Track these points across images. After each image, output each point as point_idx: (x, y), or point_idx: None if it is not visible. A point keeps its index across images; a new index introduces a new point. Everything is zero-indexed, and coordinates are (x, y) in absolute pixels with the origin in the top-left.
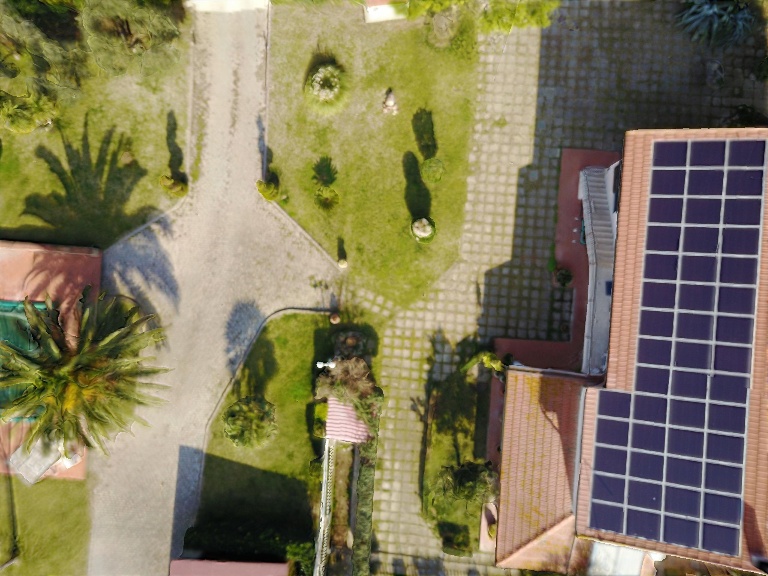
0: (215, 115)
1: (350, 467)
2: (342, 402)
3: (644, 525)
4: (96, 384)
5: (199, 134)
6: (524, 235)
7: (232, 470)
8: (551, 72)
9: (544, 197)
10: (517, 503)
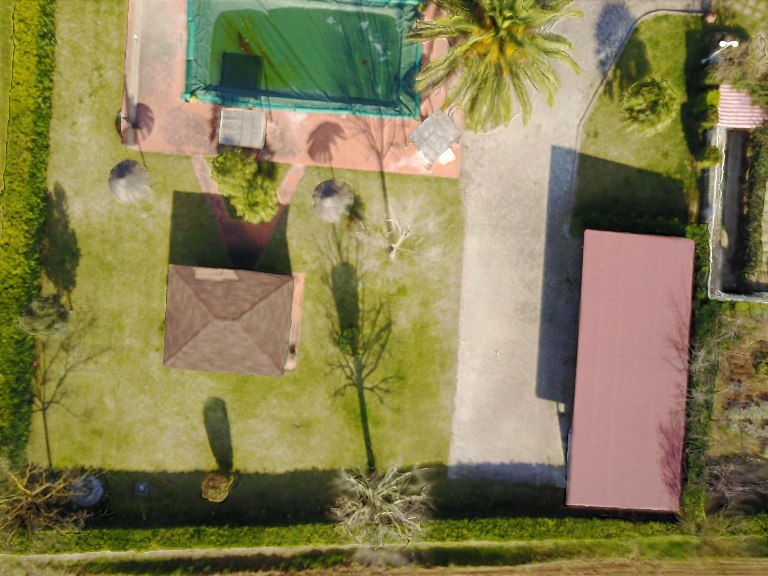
0: None
1: (723, 168)
2: (735, 88)
3: None
4: (534, 34)
5: None
6: None
7: (606, 169)
8: None
9: None
10: None
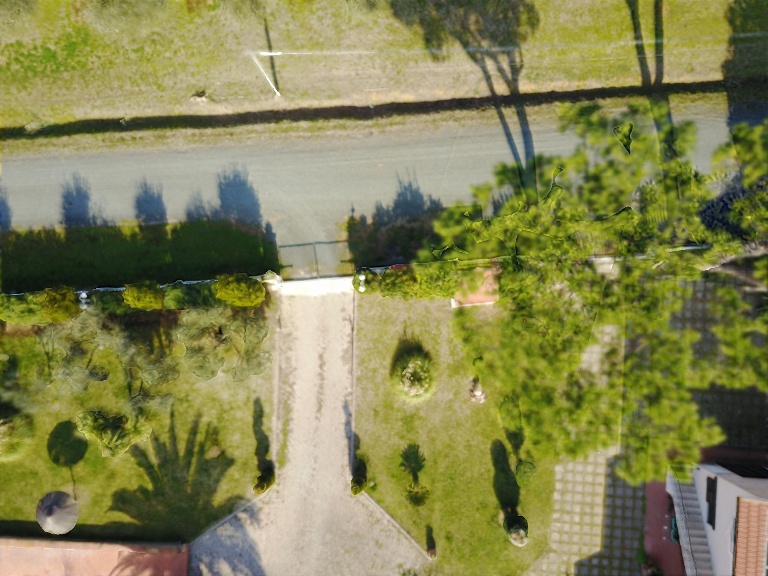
0: (301, 399)
1: None
2: None
3: None
4: None
5: (285, 419)
6: (612, 525)
7: None
8: (636, 361)
9: (632, 487)
10: None
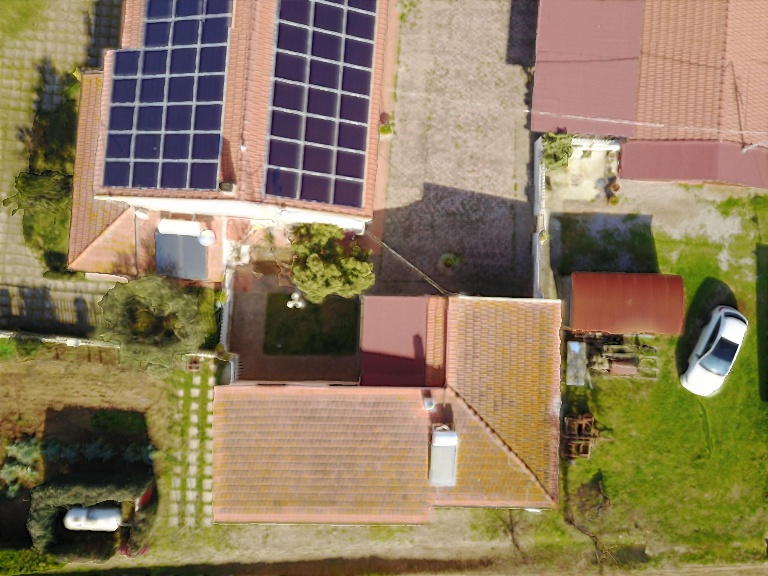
0: None
1: None
2: None
3: (146, 175)
4: None
5: None
6: None
7: None
8: None
9: None
10: (86, 204)
